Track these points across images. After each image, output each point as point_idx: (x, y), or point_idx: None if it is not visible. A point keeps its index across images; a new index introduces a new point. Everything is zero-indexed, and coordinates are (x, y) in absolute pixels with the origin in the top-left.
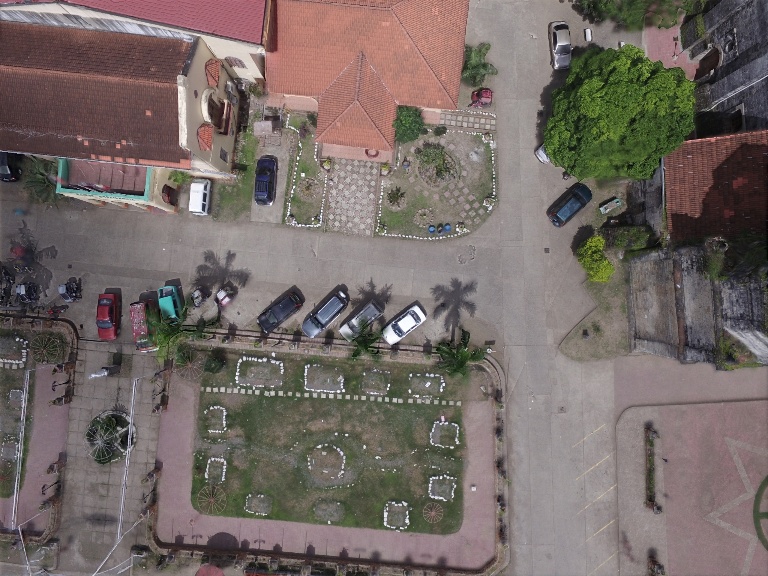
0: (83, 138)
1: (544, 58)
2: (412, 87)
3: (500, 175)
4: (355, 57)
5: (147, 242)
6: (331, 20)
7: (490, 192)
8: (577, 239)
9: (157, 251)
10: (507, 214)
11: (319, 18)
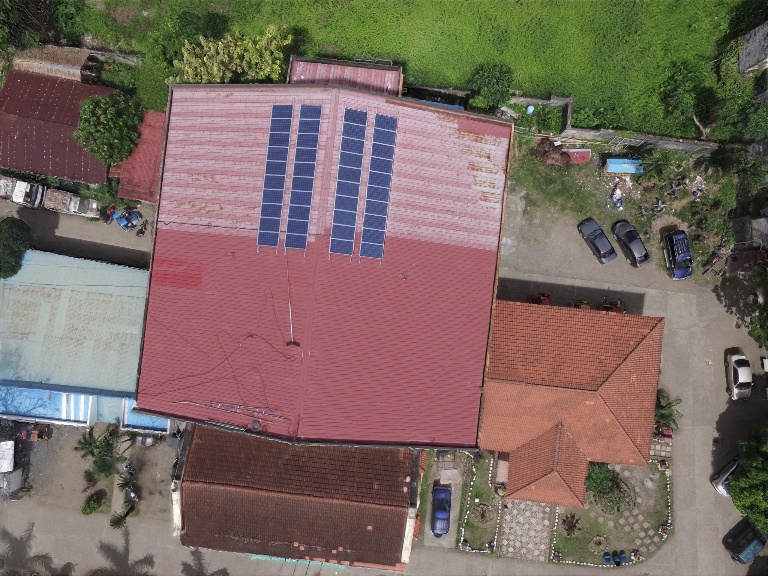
0: (299, 544)
1: (720, 384)
2: (606, 449)
3: (675, 502)
4: (553, 426)
5: (319, 565)
6: (534, 398)
7: (665, 519)
8: (753, 568)
9: (329, 575)
10: (682, 542)
11: (522, 396)
